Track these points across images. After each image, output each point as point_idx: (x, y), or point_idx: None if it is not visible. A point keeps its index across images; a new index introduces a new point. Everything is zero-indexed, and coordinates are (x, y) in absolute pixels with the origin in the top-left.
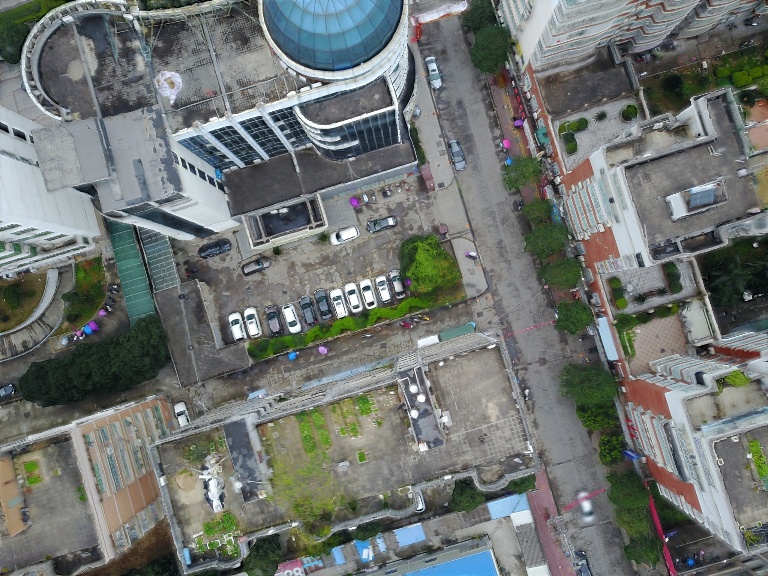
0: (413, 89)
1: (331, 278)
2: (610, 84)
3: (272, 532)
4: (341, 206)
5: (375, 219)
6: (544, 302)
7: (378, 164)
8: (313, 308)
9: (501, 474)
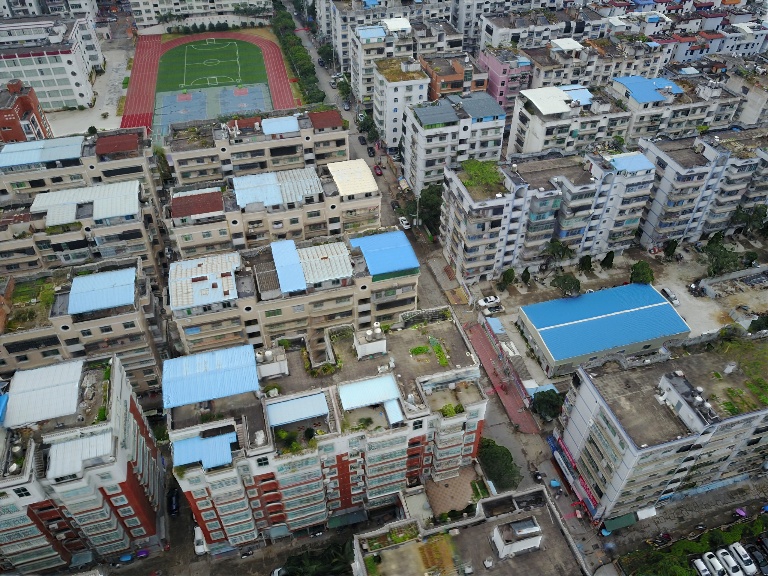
0: None
1: None
2: None
3: (764, 331)
4: None
5: None
6: None
7: None
8: (767, 555)
9: (604, 366)
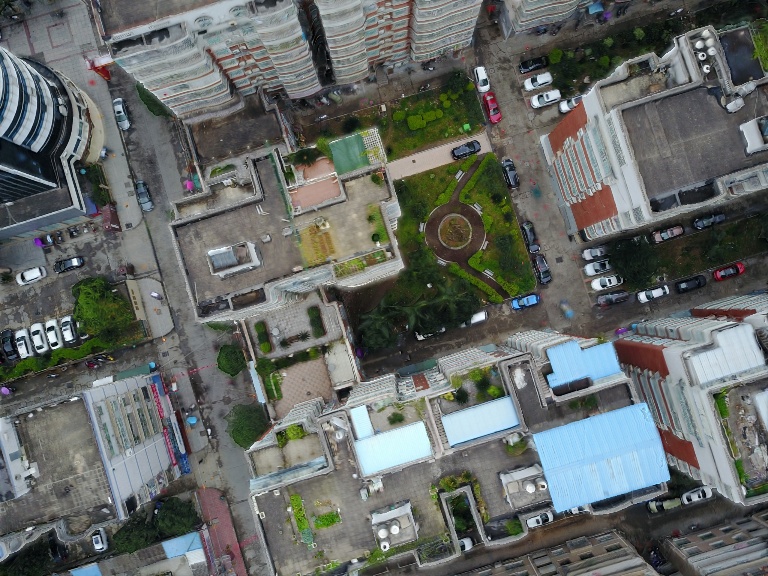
0: (71, 134)
1: (19, 318)
2: (261, 131)
3: None
4: (30, 246)
5: (61, 260)
6: (229, 341)
7: (36, 209)
8: None
9: (89, 524)
